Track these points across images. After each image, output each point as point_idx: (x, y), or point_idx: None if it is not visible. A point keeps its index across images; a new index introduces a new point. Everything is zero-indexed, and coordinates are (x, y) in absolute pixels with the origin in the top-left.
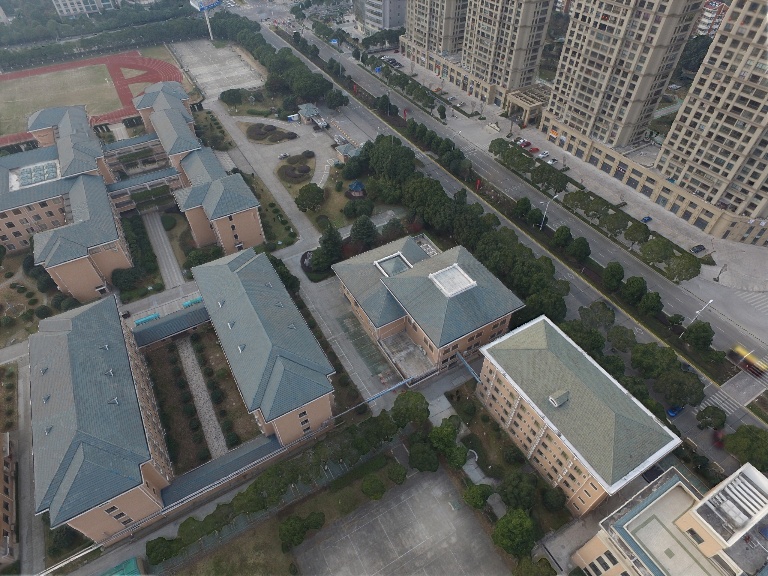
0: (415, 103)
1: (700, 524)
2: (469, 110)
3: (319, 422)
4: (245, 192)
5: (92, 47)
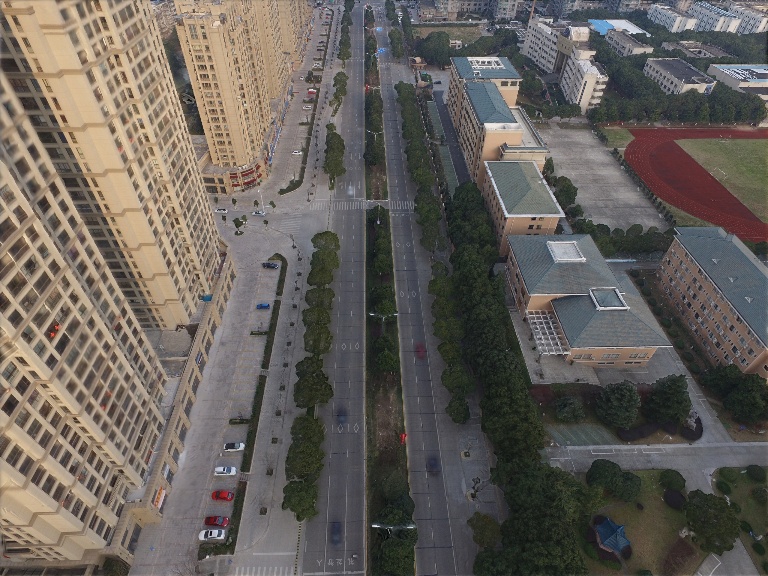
0: None
1: None
2: None
3: None
4: None
5: None
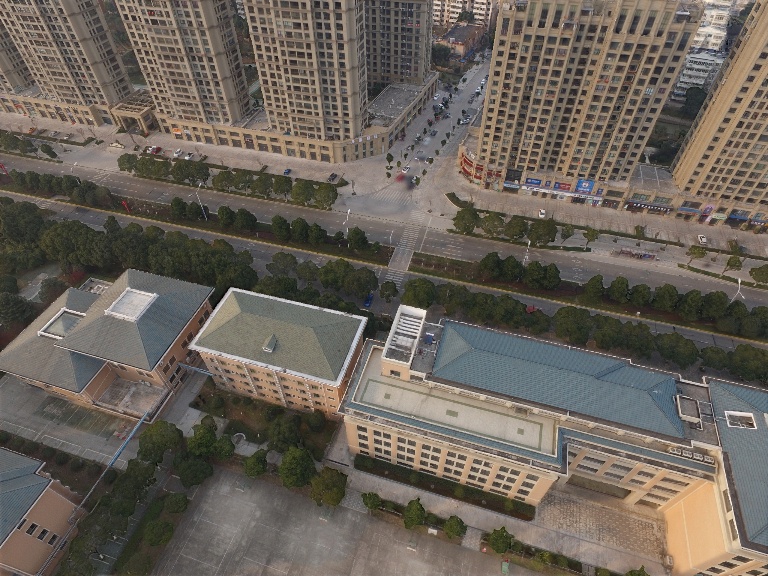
0: (12, 153)
1: (390, 363)
2: (81, 139)
3: (64, 522)
4: None
5: None
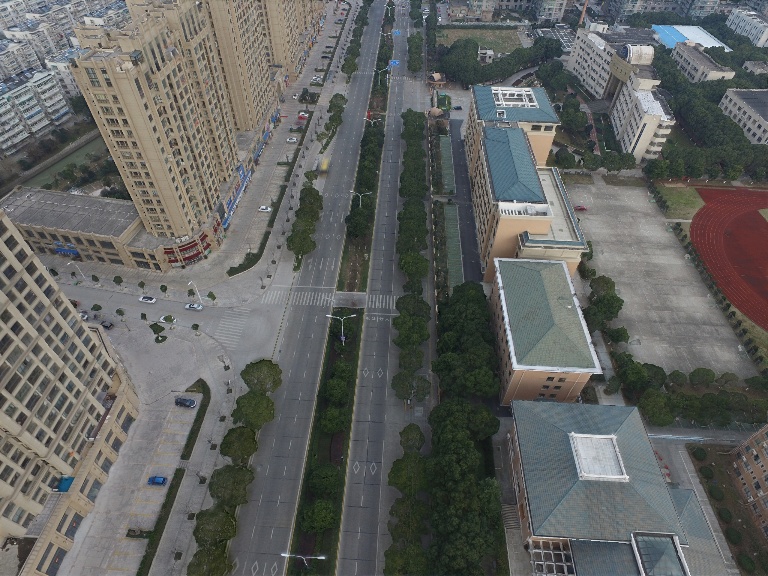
0: None
1: None
2: None
3: None
4: None
5: None
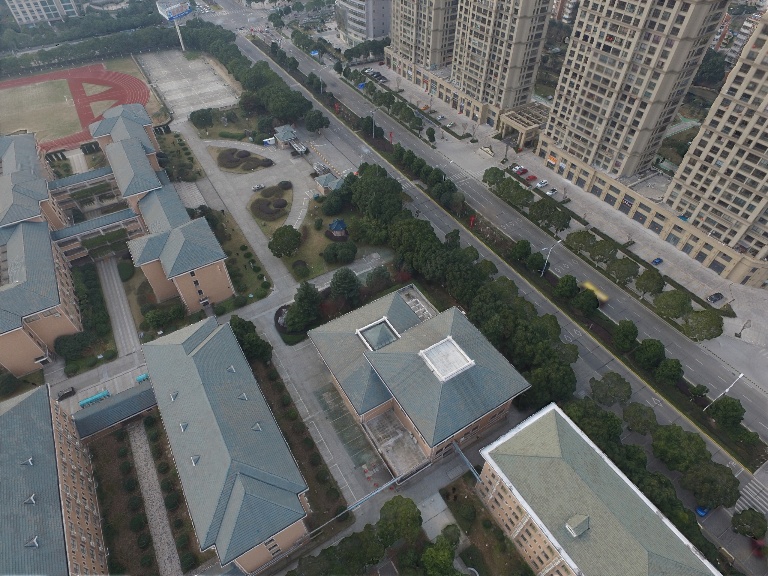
0: (402, 123)
1: None
2: (460, 131)
3: (291, 542)
4: (209, 242)
5: (52, 60)
